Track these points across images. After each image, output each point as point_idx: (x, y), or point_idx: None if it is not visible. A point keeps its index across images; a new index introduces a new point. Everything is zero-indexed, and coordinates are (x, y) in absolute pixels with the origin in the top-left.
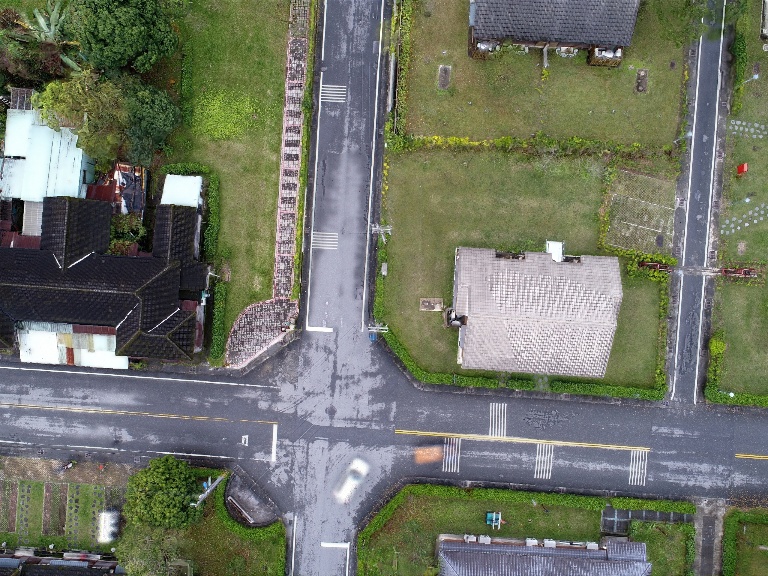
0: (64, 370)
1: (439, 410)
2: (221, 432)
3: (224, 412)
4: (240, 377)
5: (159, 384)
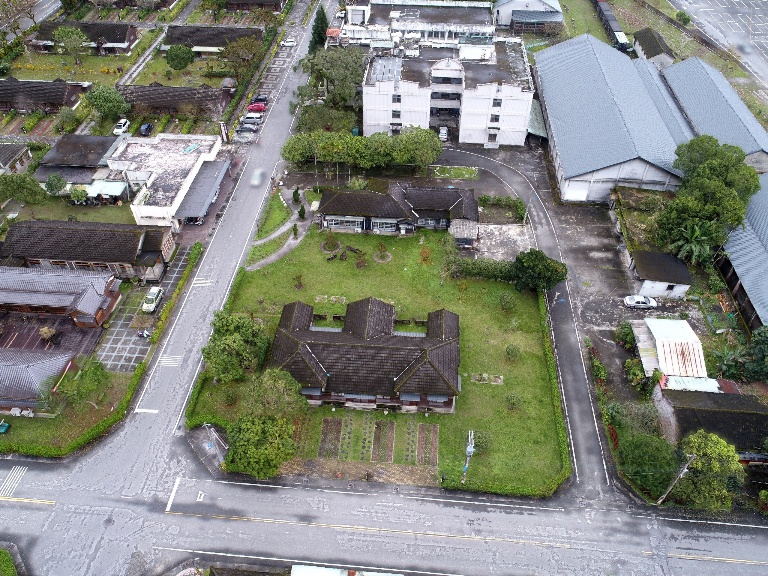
0: (371, 570)
1: (4, 522)
2: (222, 505)
3: (214, 524)
4: (190, 559)
5: (274, 553)
